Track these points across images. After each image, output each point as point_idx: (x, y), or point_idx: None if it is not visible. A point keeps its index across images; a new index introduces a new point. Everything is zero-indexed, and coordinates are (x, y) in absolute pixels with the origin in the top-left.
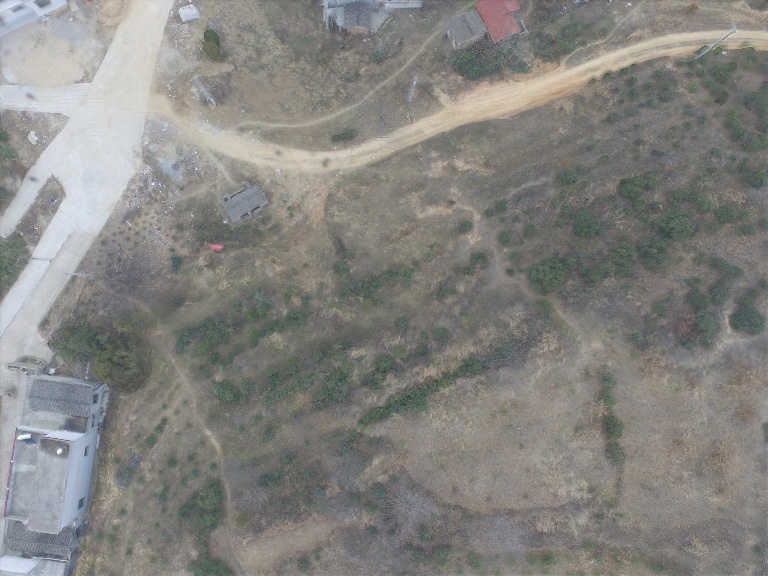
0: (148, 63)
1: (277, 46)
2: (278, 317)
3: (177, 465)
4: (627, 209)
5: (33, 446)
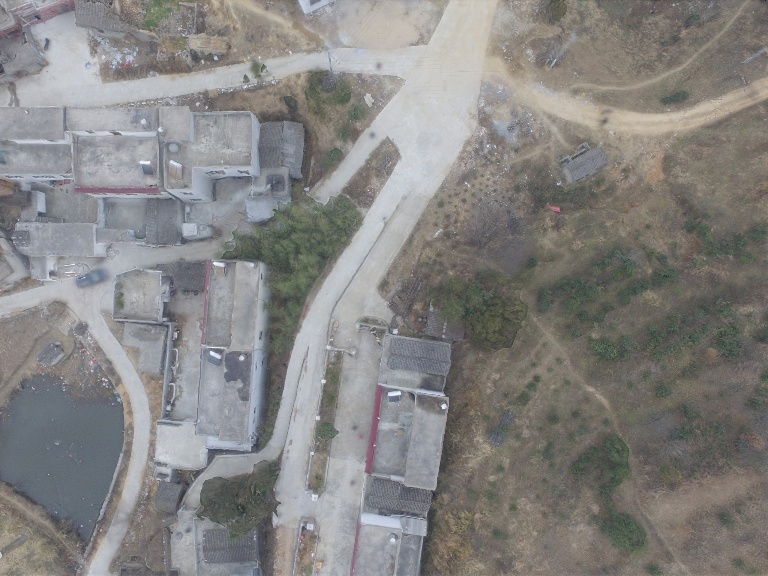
0: (484, 25)
1: (596, 10)
2: (642, 275)
3: (560, 421)
4: None
5: (394, 404)
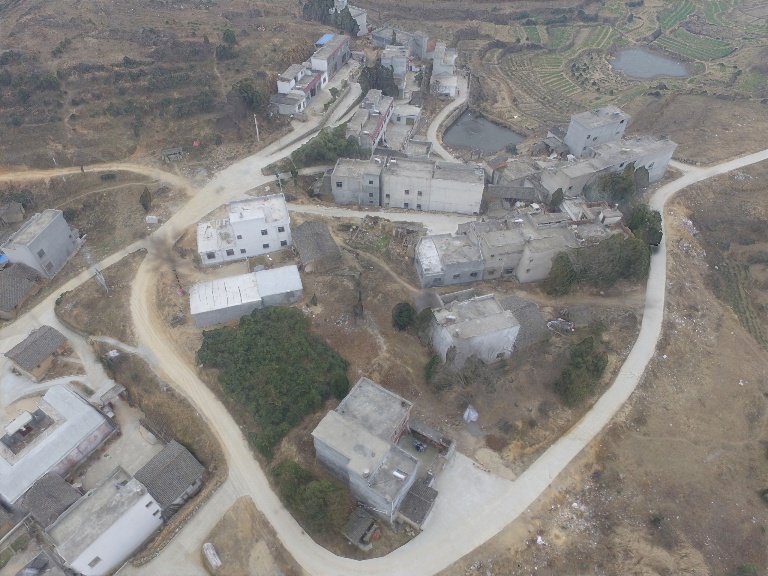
0: None
1: None
2: None
3: None
4: (3, 97)
5: None
